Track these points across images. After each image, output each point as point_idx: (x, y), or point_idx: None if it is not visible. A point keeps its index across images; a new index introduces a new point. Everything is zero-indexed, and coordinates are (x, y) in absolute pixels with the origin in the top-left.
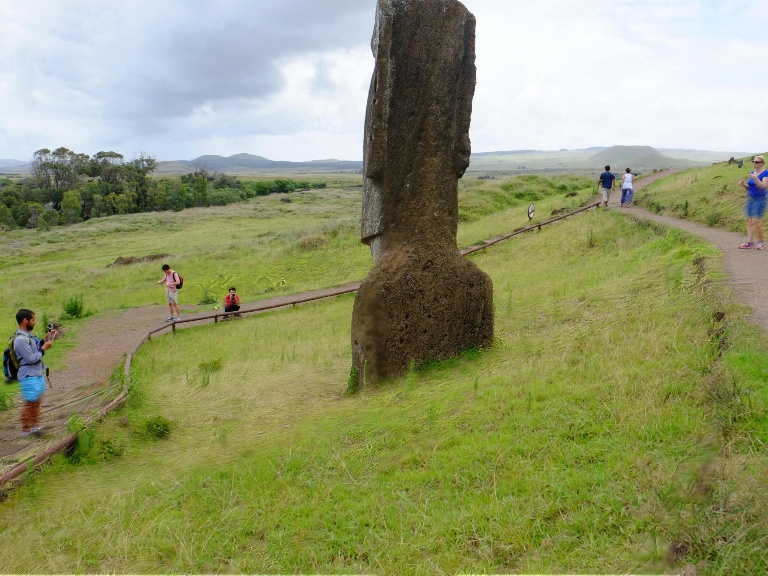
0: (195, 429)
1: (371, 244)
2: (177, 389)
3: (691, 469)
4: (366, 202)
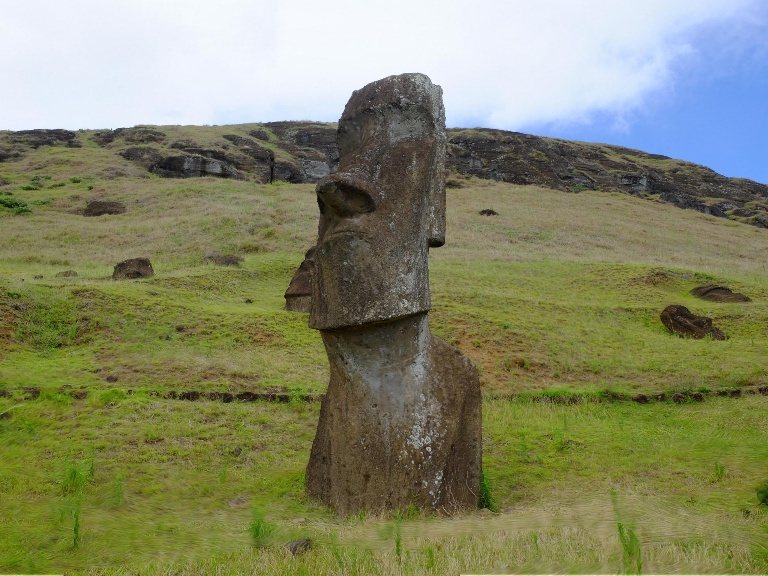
0: (725, 501)
1: (422, 320)
2: (687, 567)
3: (646, 395)
4: None
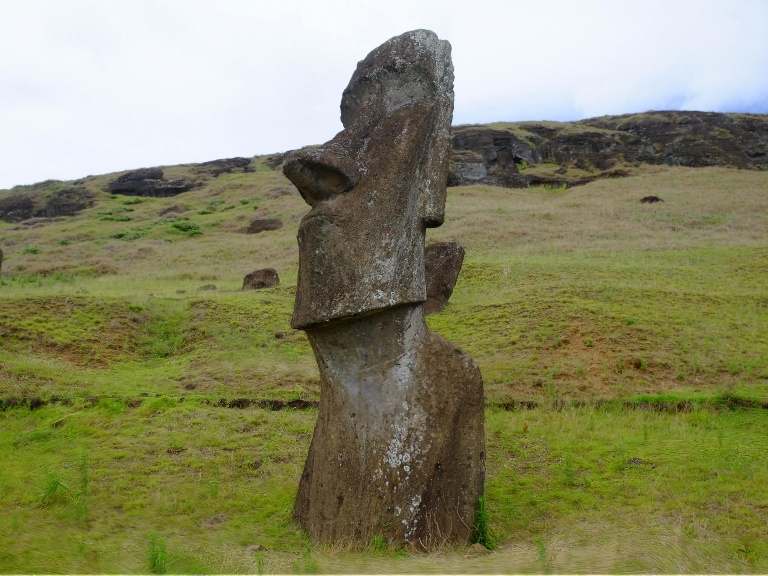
0: None
1: (409, 313)
2: None
3: None
4: (411, 251)
